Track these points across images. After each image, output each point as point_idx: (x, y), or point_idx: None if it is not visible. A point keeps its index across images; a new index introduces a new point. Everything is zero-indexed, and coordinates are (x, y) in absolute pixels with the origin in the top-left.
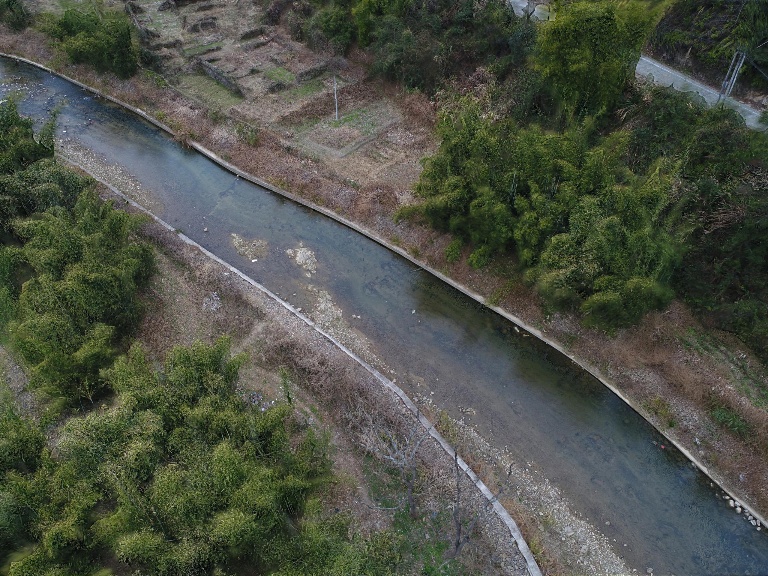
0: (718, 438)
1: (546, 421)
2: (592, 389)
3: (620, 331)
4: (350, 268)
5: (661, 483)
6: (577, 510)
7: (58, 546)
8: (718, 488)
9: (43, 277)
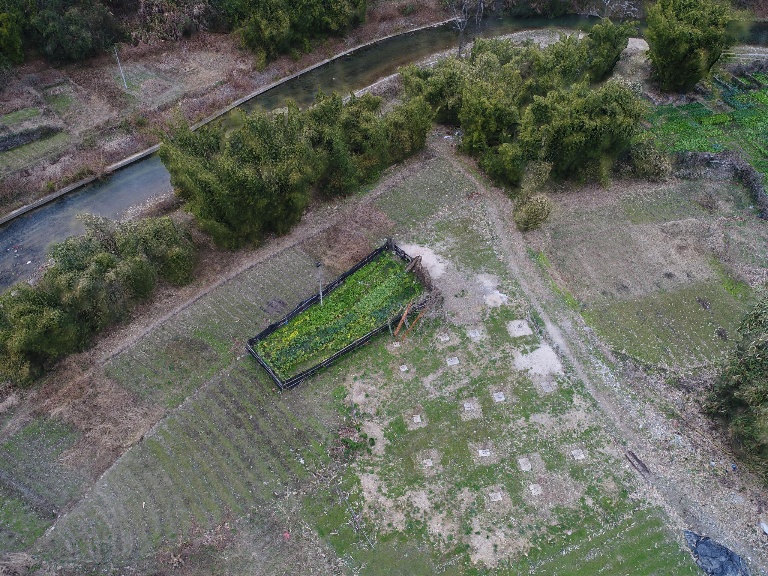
0: (412, 18)
1: None
2: (384, 43)
3: (359, 24)
4: (294, 98)
5: (428, 37)
6: (443, 51)
7: None
8: None
9: (364, 113)
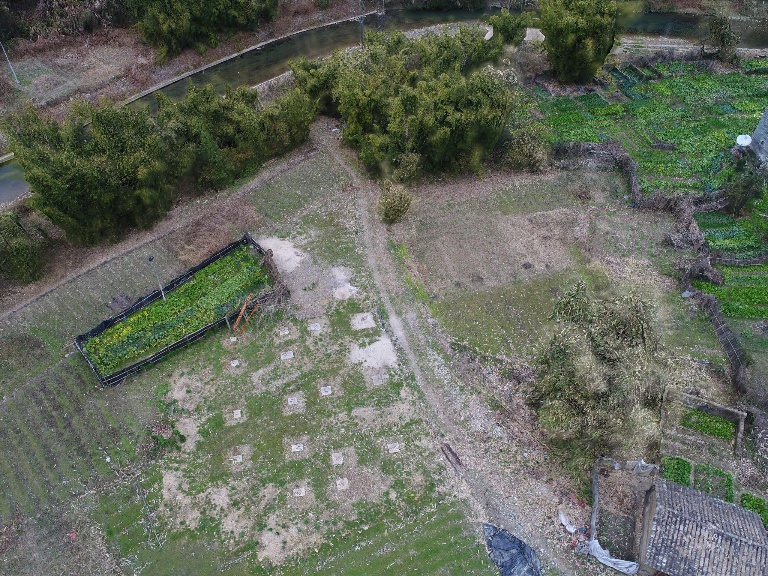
0: (329, 12)
1: (314, 47)
2: (298, 37)
3: (273, 18)
4: None
5: None
6: None
7: (405, 63)
8: (347, 21)
9: (237, 105)
